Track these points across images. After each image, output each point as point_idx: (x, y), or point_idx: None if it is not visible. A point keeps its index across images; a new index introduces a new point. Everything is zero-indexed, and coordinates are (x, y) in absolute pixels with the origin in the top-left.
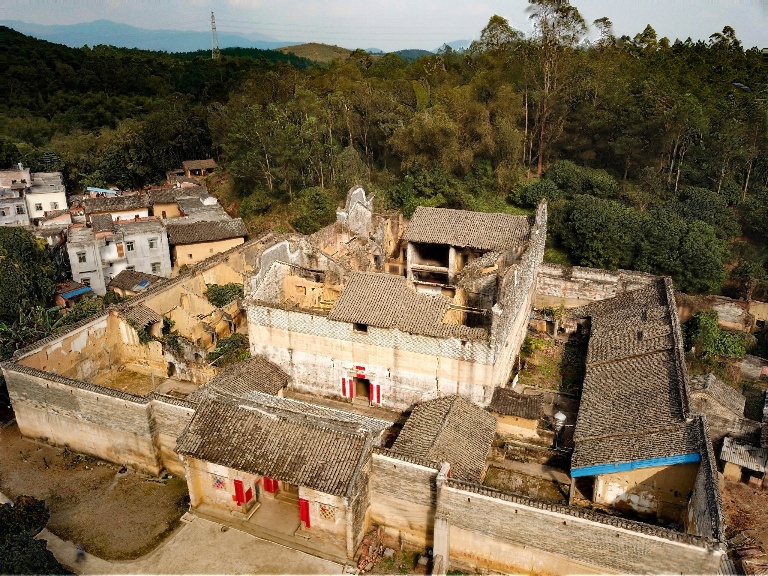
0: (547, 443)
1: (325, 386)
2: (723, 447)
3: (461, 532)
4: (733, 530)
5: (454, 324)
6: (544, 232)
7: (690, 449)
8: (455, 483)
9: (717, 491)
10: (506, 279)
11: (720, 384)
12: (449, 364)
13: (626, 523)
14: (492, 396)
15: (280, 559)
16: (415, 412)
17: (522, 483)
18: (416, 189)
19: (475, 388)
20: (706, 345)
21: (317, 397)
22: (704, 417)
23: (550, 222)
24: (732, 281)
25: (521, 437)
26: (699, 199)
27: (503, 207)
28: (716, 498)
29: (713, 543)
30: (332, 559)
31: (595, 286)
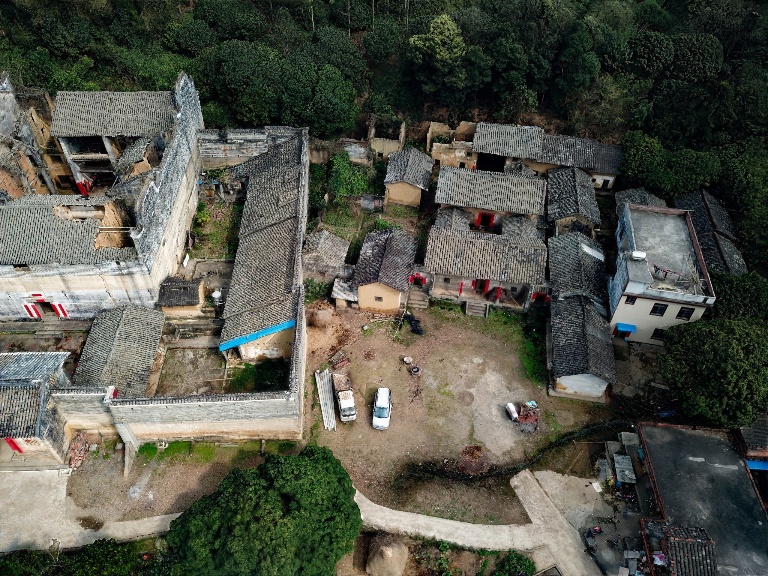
0: (211, 316)
1: (11, 313)
2: (333, 287)
3: (137, 425)
4: (336, 348)
5: (106, 248)
6: (194, 98)
7: (291, 317)
8: (118, 402)
9: (297, 353)
10: (139, 202)
11: (331, 238)
12: (113, 279)
13: (236, 397)
14: (159, 293)
15: (5, 483)
16: (94, 326)
17: (193, 357)
18: (59, 50)
19: (142, 292)
20: (338, 186)
21: (7, 323)
22: (302, 288)
23: (205, 74)
24: (364, 113)
25: (191, 316)
26: (327, 42)
27: (160, 54)
28: (293, 361)
29: (287, 395)
30: (48, 468)
31: (249, 145)
